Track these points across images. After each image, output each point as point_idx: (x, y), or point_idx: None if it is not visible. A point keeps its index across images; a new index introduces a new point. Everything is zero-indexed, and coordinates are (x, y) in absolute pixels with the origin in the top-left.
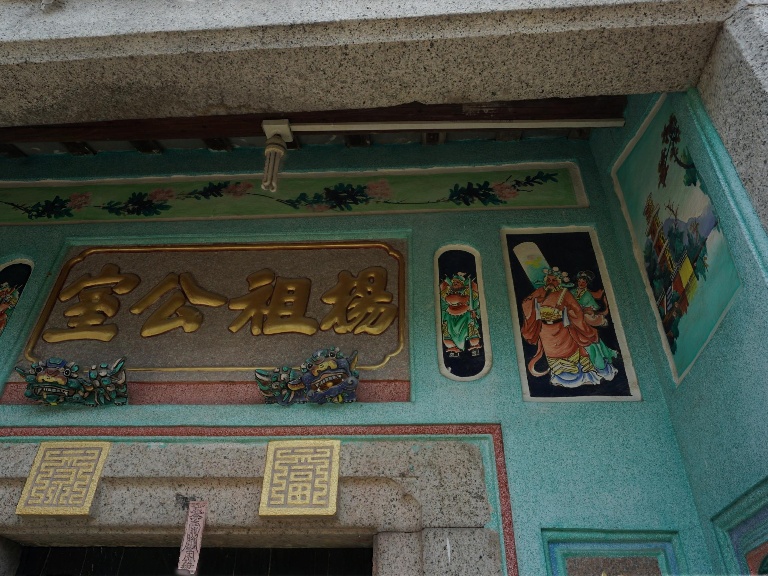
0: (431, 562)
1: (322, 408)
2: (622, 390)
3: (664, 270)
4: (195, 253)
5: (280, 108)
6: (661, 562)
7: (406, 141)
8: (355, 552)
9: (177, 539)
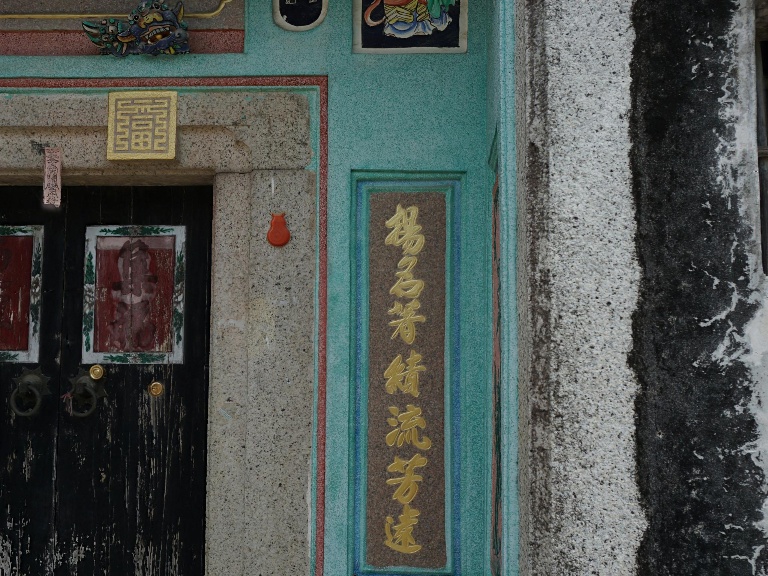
0: (257, 197)
1: (157, 59)
2: (451, 41)
3: None
4: None
5: None
6: (447, 196)
7: None
8: (207, 189)
9: (42, 179)
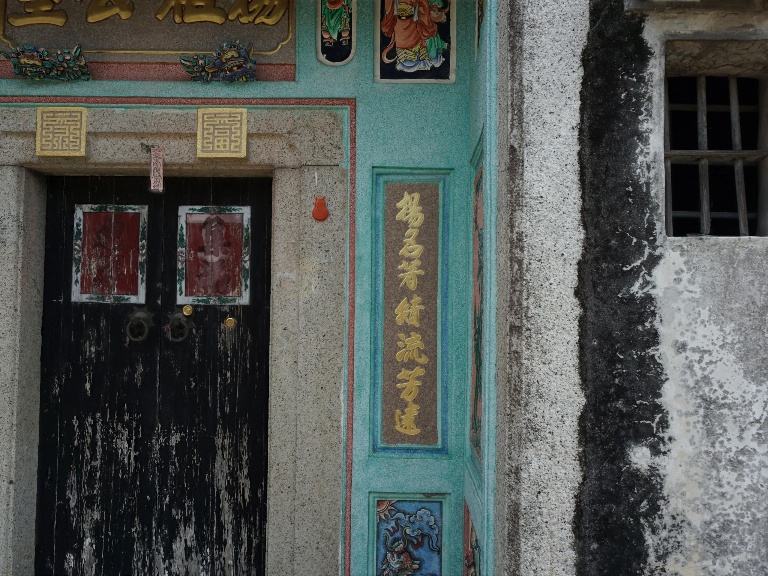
0: (305, 185)
1: (232, 85)
2: (444, 75)
3: None
4: None
5: None
6: (441, 186)
7: None
8: (266, 180)
9: (148, 171)
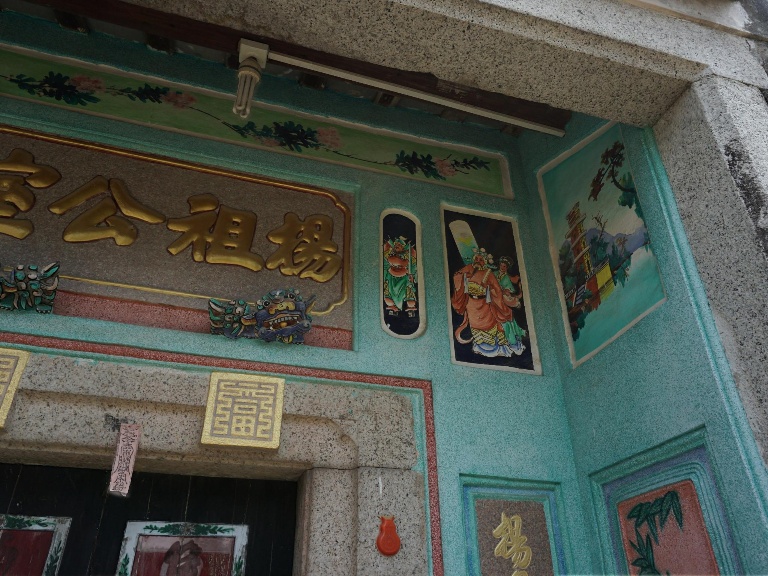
0: (365, 497)
1: (269, 346)
2: (528, 364)
3: (580, 270)
4: (128, 159)
5: (300, 41)
6: (546, 506)
7: (359, 95)
8: (276, 484)
9: (97, 460)
